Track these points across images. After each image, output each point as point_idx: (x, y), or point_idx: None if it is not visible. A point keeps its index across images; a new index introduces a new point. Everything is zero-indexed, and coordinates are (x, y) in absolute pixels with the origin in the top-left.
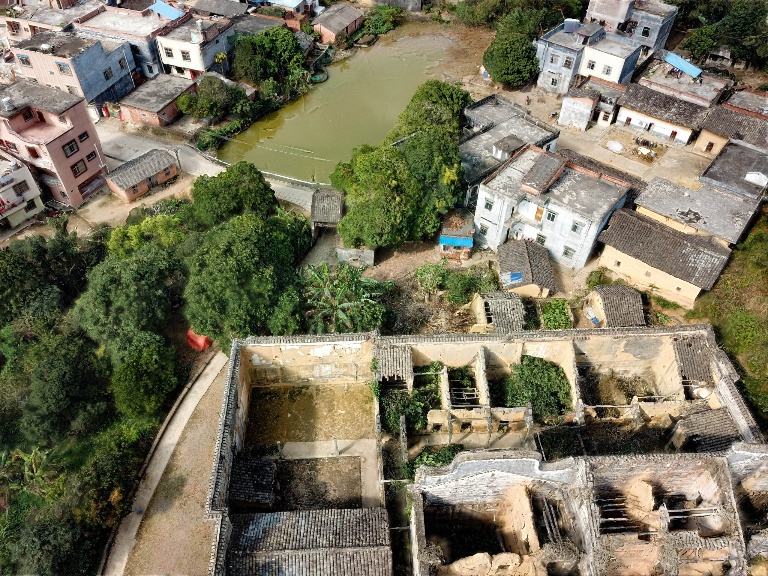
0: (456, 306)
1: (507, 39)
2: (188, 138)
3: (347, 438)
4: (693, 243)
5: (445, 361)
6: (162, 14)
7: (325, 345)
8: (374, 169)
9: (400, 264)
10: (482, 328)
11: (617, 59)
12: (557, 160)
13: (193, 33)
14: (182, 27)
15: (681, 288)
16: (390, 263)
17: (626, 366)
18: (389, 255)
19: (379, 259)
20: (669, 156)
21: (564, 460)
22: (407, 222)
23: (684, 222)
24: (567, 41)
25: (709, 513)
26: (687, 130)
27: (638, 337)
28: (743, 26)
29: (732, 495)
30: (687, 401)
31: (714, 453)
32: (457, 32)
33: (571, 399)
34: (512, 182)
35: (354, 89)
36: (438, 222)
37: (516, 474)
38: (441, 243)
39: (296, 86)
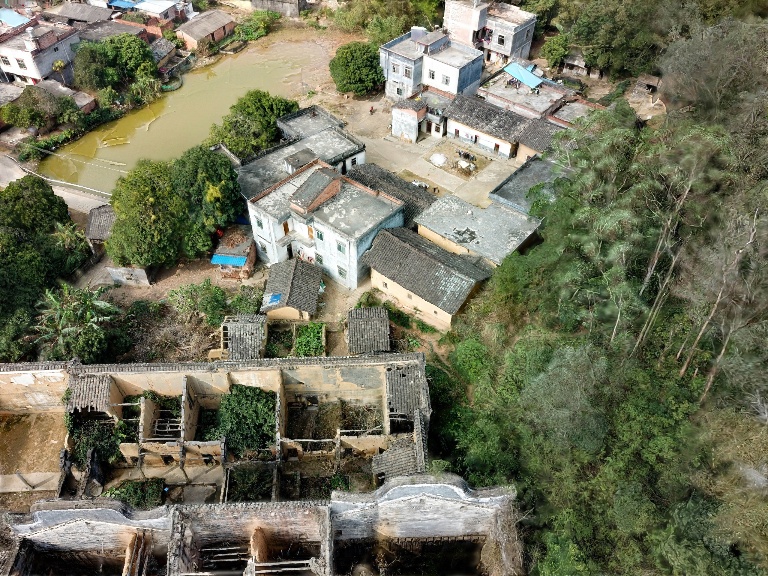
0: (211, 329)
1: (349, 47)
2: (11, 149)
3: (49, 471)
4: (449, 265)
5: (158, 390)
6: (4, 21)
7: (22, 374)
8: (133, 186)
9: (178, 283)
10: (219, 354)
11: (452, 69)
12: (327, 177)
13: (26, 41)
14: (23, 34)
15: (437, 312)
16: (168, 282)
17: (355, 395)
18: (171, 273)
19: (159, 277)
20: (489, 170)
21: (156, 509)
22: (171, 241)
23: (456, 242)
24: (410, 50)
25: (300, 567)
26: (507, 143)
27: (350, 367)
28: (588, 35)
29: (327, 548)
30: (392, 435)
31: (321, 501)
32: (330, 39)
33: (276, 432)
34: (284, 199)
35: (205, 98)
36: (208, 240)
37: (110, 523)
38: (212, 262)
39: (141, 95)
